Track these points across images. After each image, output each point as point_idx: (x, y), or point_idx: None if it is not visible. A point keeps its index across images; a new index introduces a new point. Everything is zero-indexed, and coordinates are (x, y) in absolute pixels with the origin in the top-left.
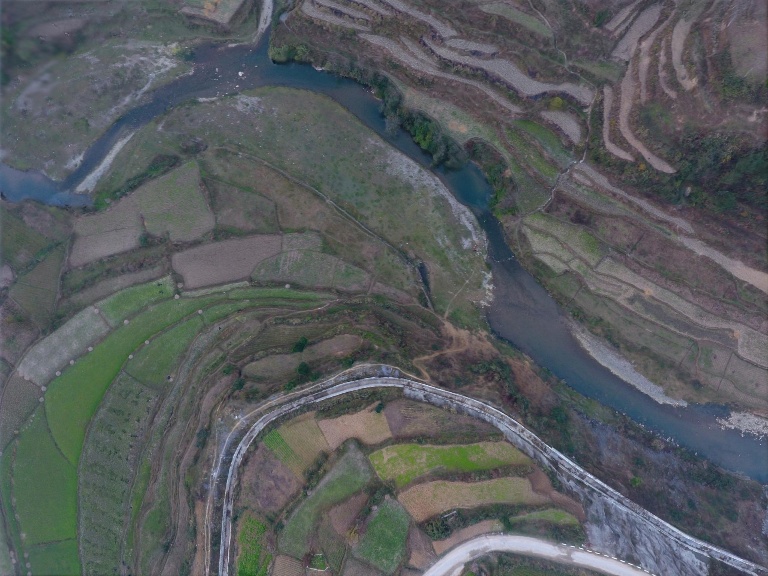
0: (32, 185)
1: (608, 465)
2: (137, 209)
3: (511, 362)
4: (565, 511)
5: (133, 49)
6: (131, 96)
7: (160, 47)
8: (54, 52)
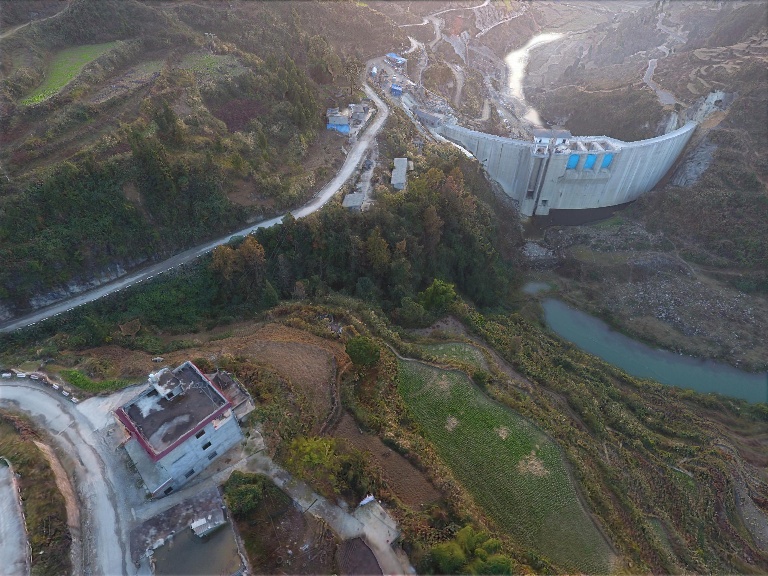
0: (558, 0)
1: (506, 30)
2: (558, 5)
3: (533, 32)
4: (498, 5)
5: (605, 7)
6: (591, 7)
7: (608, 9)
8: (598, 1)
